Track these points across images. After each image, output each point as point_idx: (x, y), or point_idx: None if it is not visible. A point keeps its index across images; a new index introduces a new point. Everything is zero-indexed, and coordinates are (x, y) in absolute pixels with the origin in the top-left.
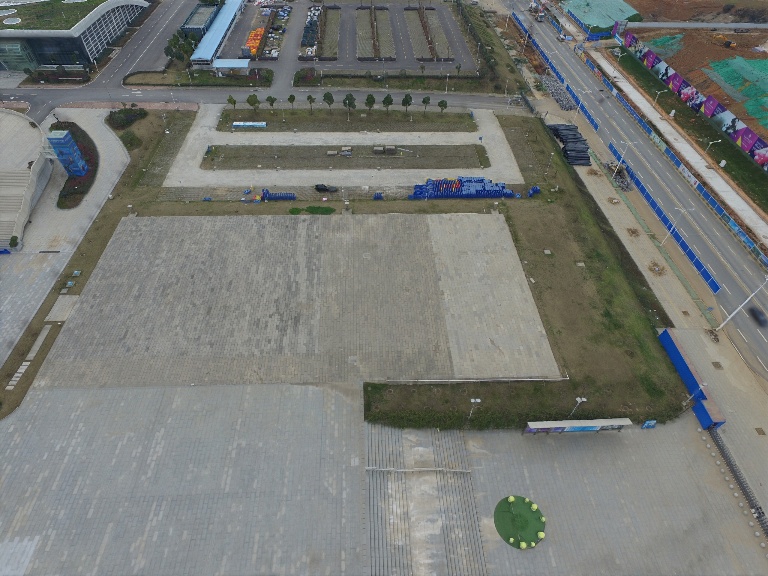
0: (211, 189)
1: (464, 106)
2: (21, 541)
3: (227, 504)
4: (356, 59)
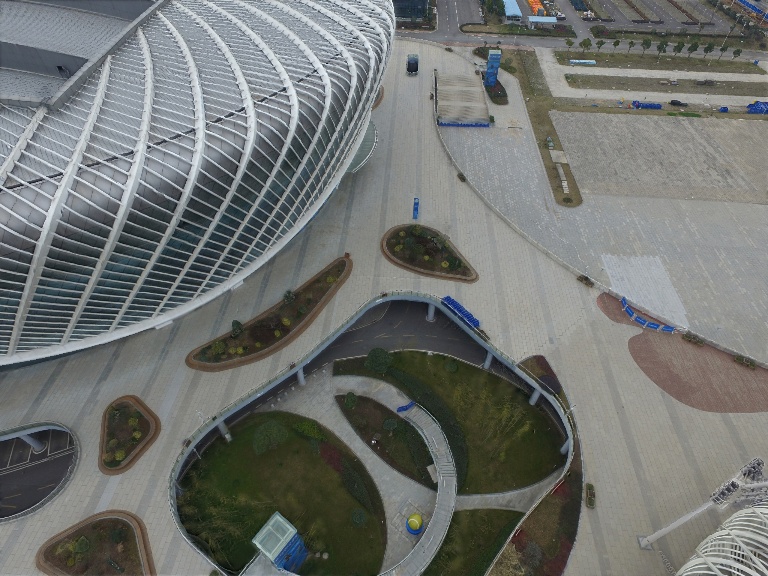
0: (591, 100)
1: (742, 58)
2: (649, 257)
3: (762, 253)
4: (630, 21)
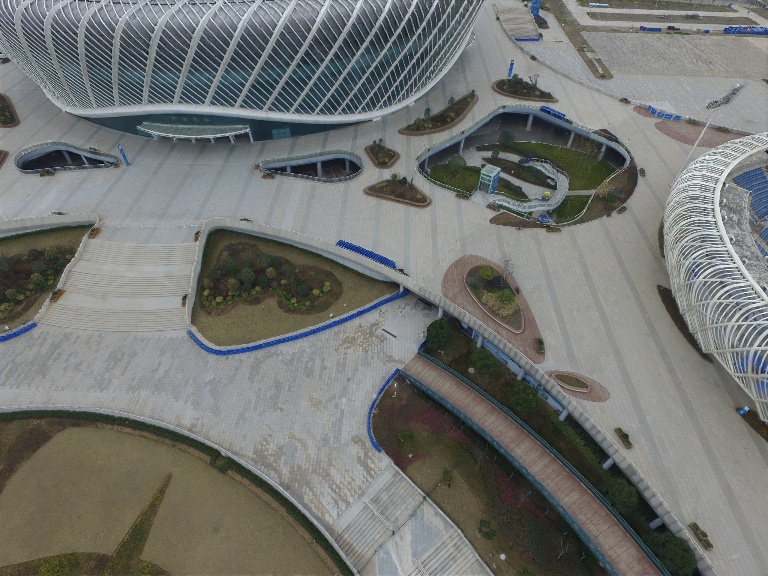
0: None
1: (720, 3)
2: (661, 101)
3: None
4: None
